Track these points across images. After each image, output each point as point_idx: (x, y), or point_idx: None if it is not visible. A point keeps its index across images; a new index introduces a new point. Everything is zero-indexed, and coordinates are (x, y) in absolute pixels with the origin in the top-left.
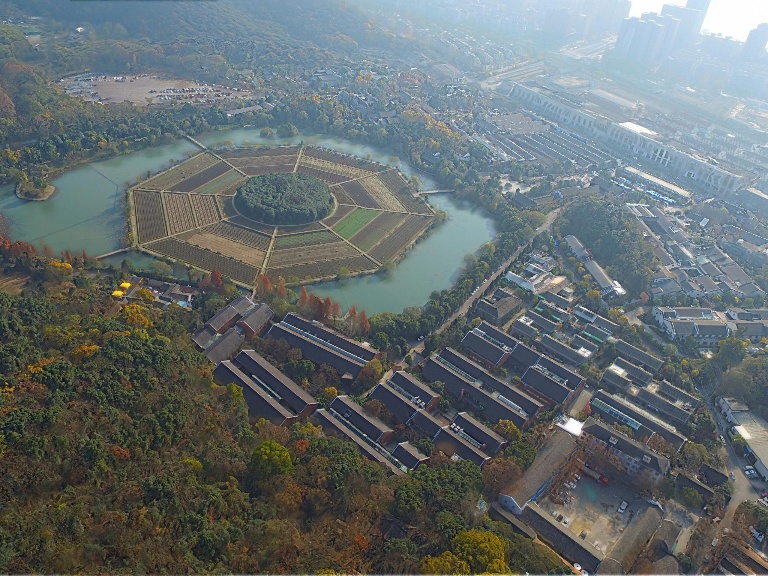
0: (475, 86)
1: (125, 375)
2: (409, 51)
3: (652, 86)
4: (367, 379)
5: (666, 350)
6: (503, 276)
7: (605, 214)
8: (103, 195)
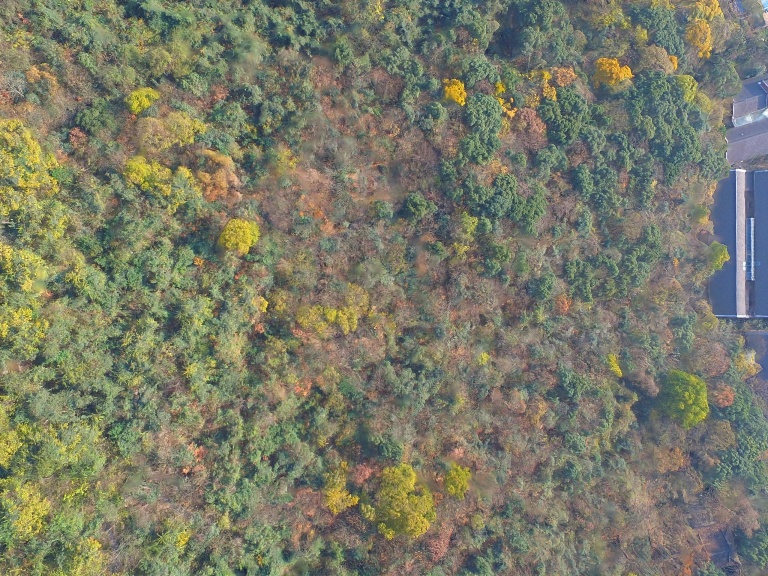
0: None
1: (629, 159)
2: None
3: None
4: None
5: None
6: None
7: None
8: None
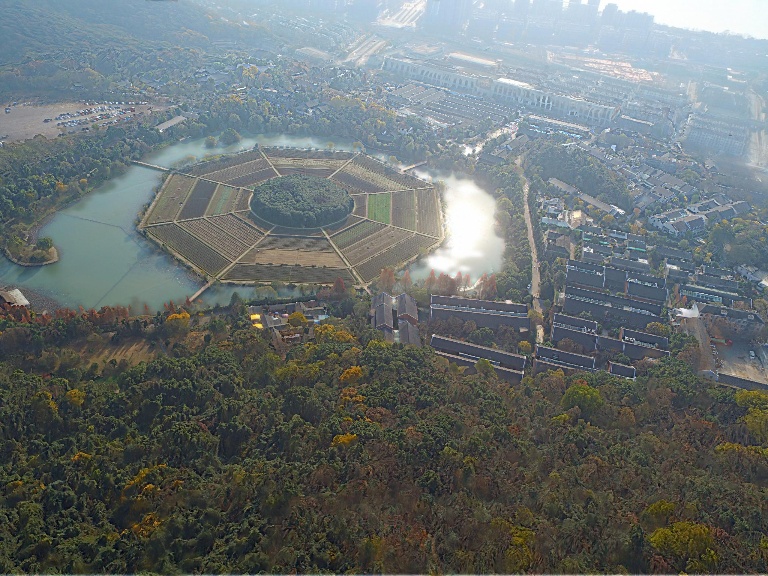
0: (352, 65)
1: None
2: (261, 39)
3: (479, 44)
4: (534, 328)
5: (681, 245)
6: (540, 222)
7: (570, 155)
8: (115, 240)
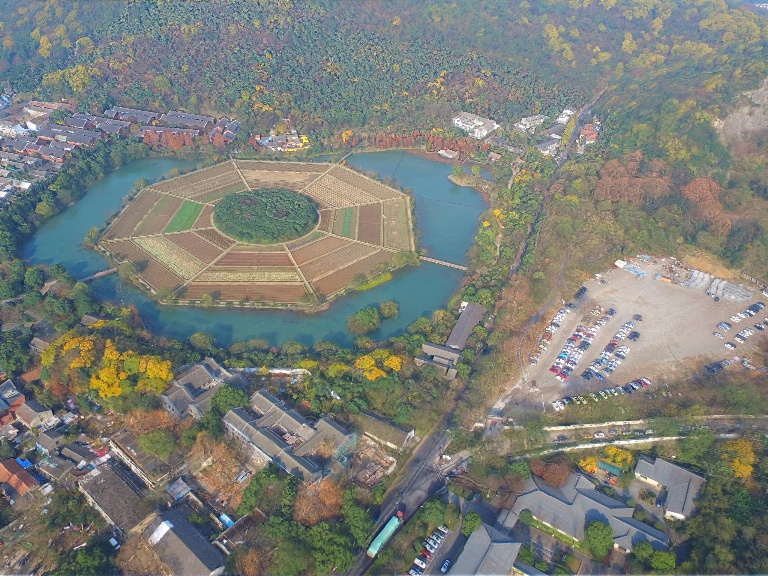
0: None
1: None
2: None
3: None
4: None
5: None
6: None
7: None
8: (421, 190)
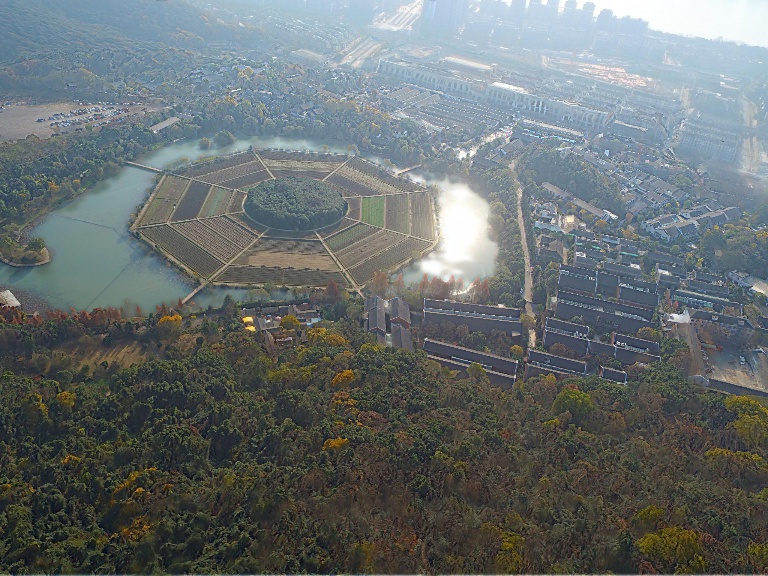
0: (347, 67)
1: None
2: (256, 40)
3: (474, 48)
4: (526, 332)
5: (673, 251)
6: (533, 226)
7: (564, 160)
8: (108, 242)
